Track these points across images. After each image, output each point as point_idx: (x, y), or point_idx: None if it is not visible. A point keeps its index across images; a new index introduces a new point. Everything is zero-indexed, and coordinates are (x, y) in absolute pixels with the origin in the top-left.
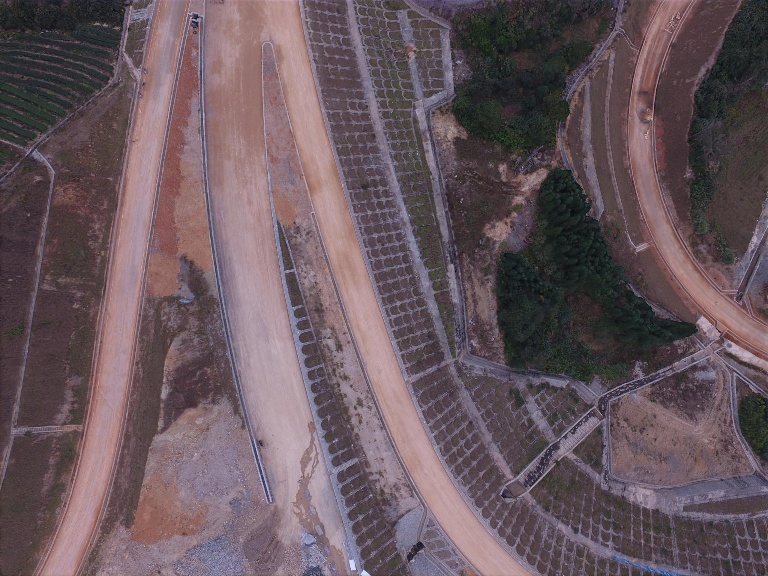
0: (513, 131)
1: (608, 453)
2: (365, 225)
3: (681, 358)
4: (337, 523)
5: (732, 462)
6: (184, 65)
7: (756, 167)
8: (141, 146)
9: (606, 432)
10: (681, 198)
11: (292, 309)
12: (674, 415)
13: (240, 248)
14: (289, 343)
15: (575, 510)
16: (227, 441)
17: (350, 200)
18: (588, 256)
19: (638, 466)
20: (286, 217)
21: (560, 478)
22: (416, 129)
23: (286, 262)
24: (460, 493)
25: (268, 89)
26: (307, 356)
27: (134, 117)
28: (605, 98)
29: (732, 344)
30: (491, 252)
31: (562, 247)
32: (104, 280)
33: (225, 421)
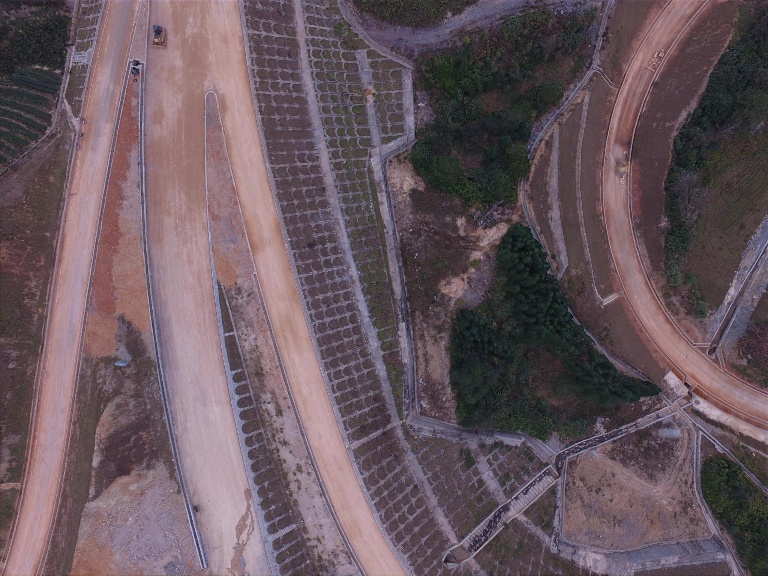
0: (472, 184)
1: (561, 514)
2: (309, 286)
3: (645, 414)
4: None
5: (690, 525)
6: (124, 115)
7: (738, 215)
8: (79, 200)
9: (560, 492)
10: (655, 247)
11: (231, 373)
12: (633, 474)
13: (179, 309)
14: (227, 408)
15: (520, 575)
16: (162, 506)
17: (294, 261)
18: (547, 316)
19: (590, 530)
20: (227, 277)
21: (508, 541)
22: (371, 180)
23: (226, 325)
24: (399, 561)
25: (211, 142)
26: (245, 422)
27: (72, 169)
28: (577, 143)
29: (700, 401)
30: (446, 309)
31: (520, 305)
32: (41, 338)
33: (160, 486)
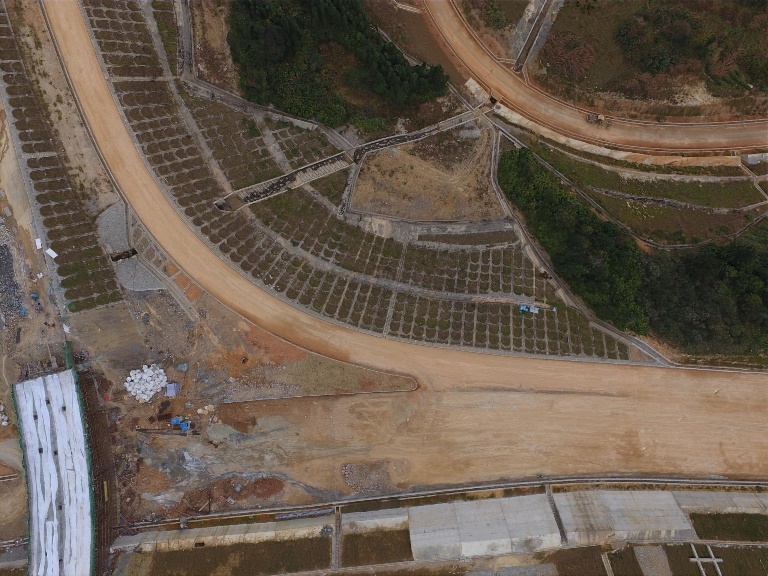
0: None
1: (351, 191)
2: None
3: (447, 117)
4: (25, 204)
5: (483, 207)
6: None
7: None
8: None
9: (354, 175)
10: None
11: None
12: (431, 166)
13: None
14: None
15: (299, 229)
16: None
17: None
18: None
19: (375, 198)
20: None
21: (290, 203)
22: None
23: None
24: (161, 189)
25: None
26: (2, 49)
27: None
28: None
29: (501, 106)
30: None
31: None
32: None
33: None
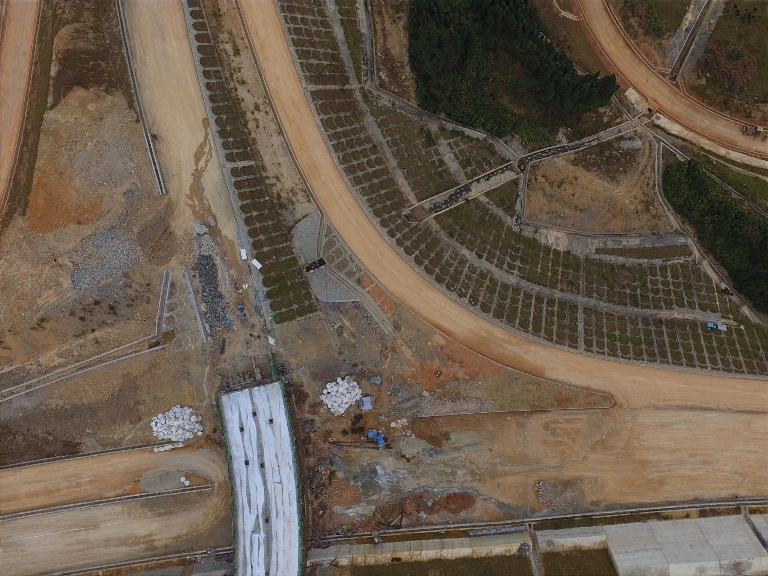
0: None
1: (523, 202)
2: None
3: (607, 127)
4: (229, 214)
5: (652, 220)
6: None
7: None
8: None
9: (523, 185)
10: None
11: (188, 9)
12: (595, 177)
13: None
14: (185, 42)
15: (481, 241)
16: (121, 132)
17: None
18: None
19: (551, 210)
20: None
21: (469, 214)
22: None
23: None
24: (357, 200)
25: None
26: (203, 56)
27: None
28: None
29: (661, 116)
30: None
31: None
32: None
33: (119, 113)
